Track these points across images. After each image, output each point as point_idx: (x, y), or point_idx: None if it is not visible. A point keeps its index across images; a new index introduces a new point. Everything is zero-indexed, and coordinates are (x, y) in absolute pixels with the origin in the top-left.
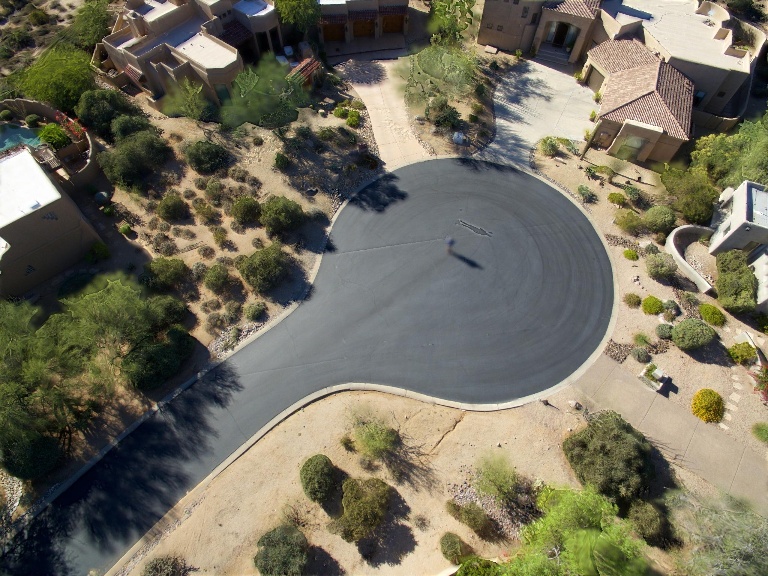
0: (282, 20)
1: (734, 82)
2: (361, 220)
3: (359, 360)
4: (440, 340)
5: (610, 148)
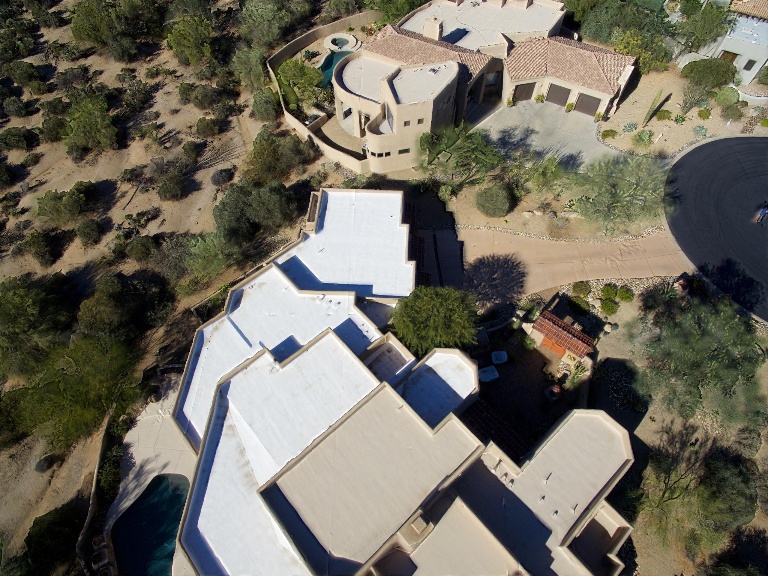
0: (472, 344)
1: None
2: None
3: None
4: None
5: None
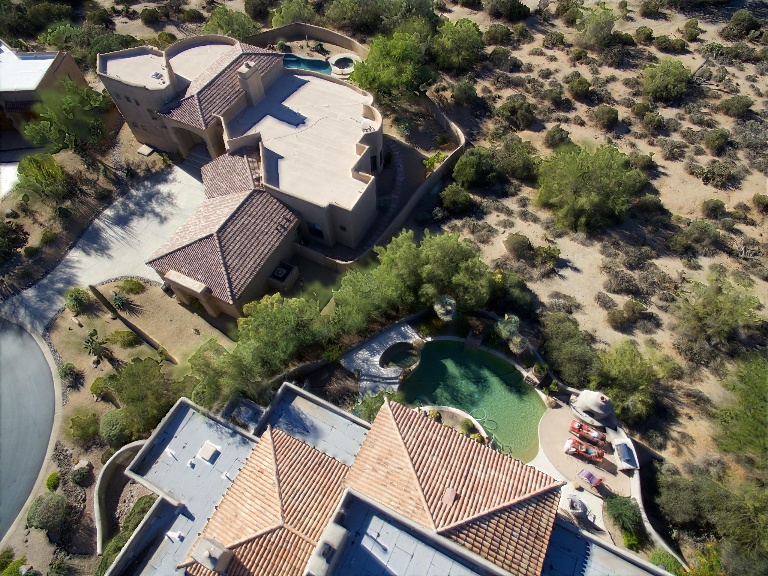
0: None
1: (344, 218)
2: None
3: None
4: None
5: (177, 298)
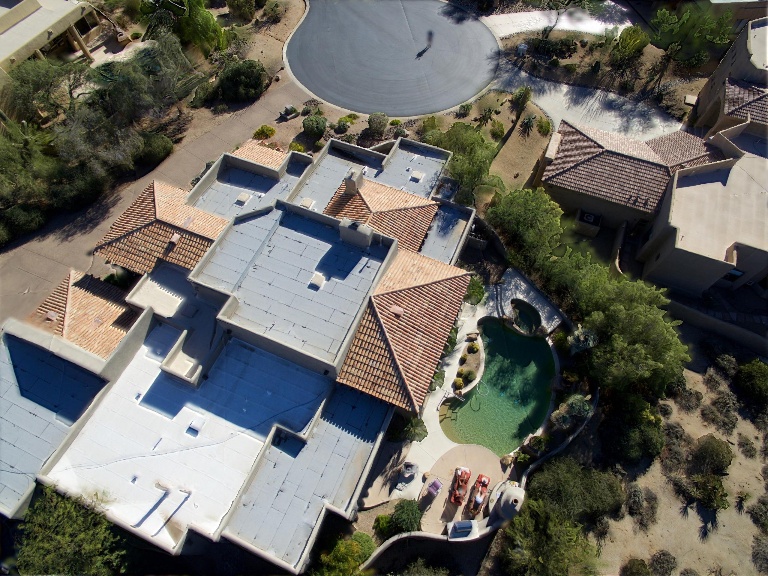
0: None
1: None
2: (429, 7)
3: (323, 8)
4: (332, 33)
5: None
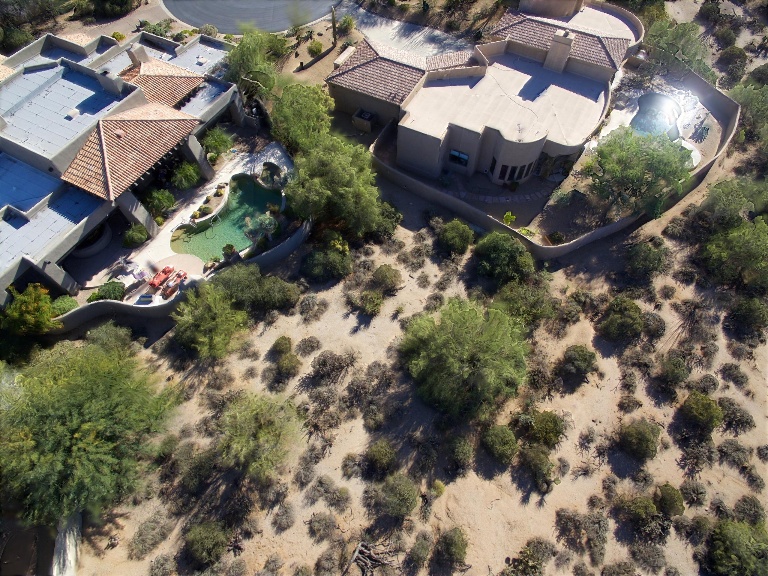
0: None
1: None
2: None
3: None
4: None
5: None
